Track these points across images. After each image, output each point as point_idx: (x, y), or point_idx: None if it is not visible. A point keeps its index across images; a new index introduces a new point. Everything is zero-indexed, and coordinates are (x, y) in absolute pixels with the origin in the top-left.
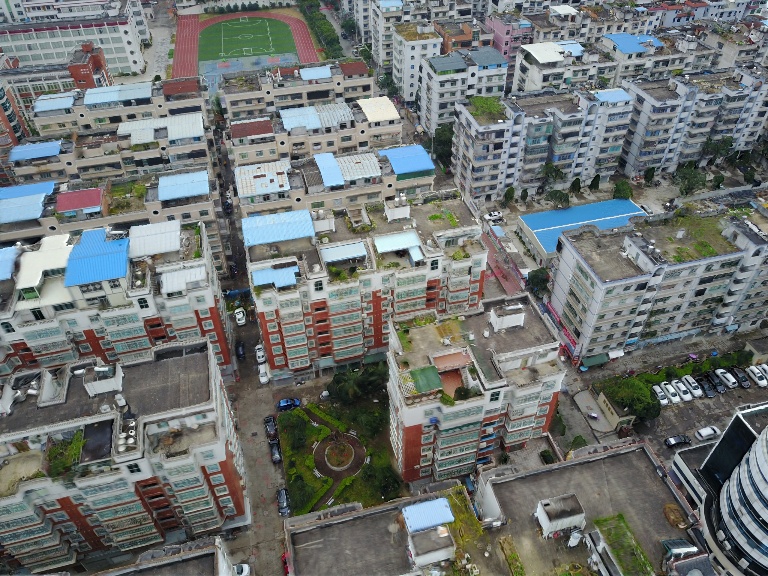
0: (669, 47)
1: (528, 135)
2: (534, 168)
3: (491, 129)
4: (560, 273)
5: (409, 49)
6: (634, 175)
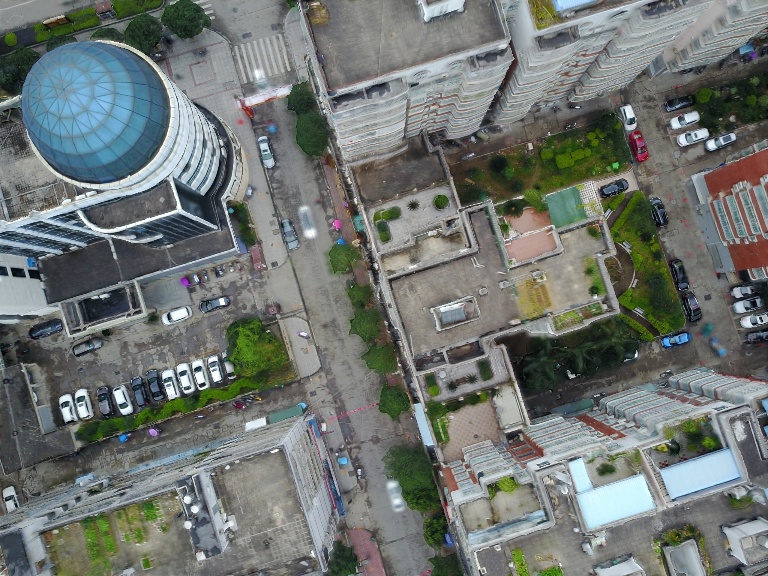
0: None
1: None
2: None
3: None
4: None
5: None
6: None
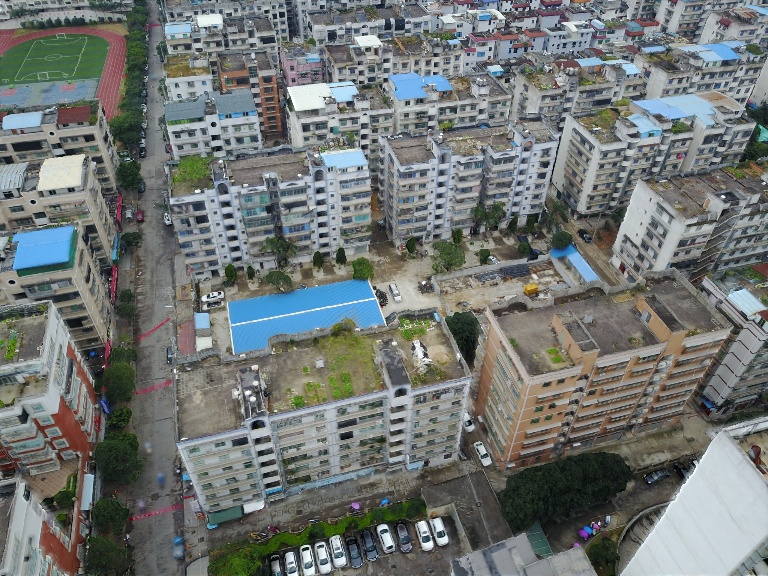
0: (463, 90)
1: (241, 206)
2: (260, 241)
3: (186, 201)
4: None
5: (173, 86)
6: (399, 243)
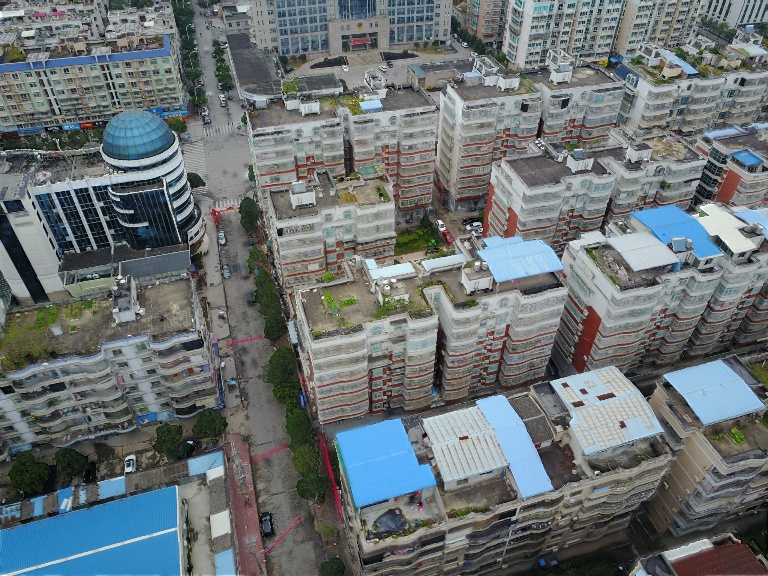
0: None
1: None
2: None
3: None
4: None
5: None
6: None
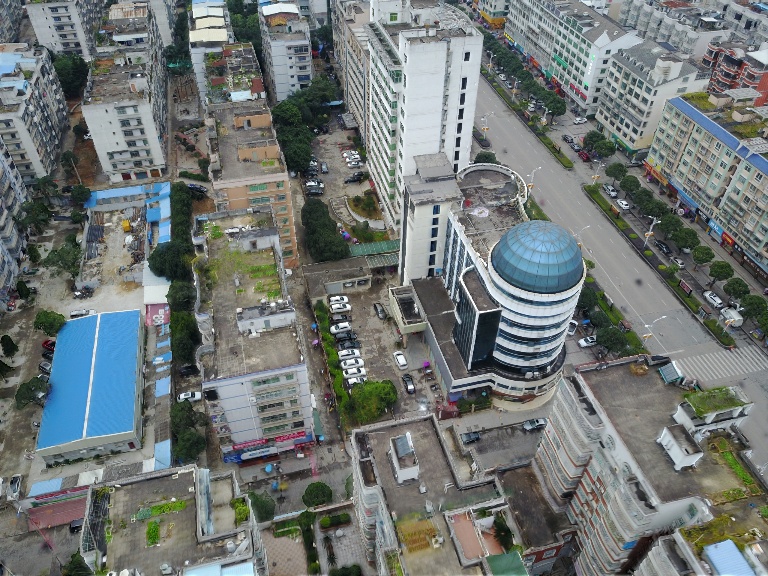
0: None
1: None
2: None
3: None
4: (230, 412)
5: None
6: (5, 306)
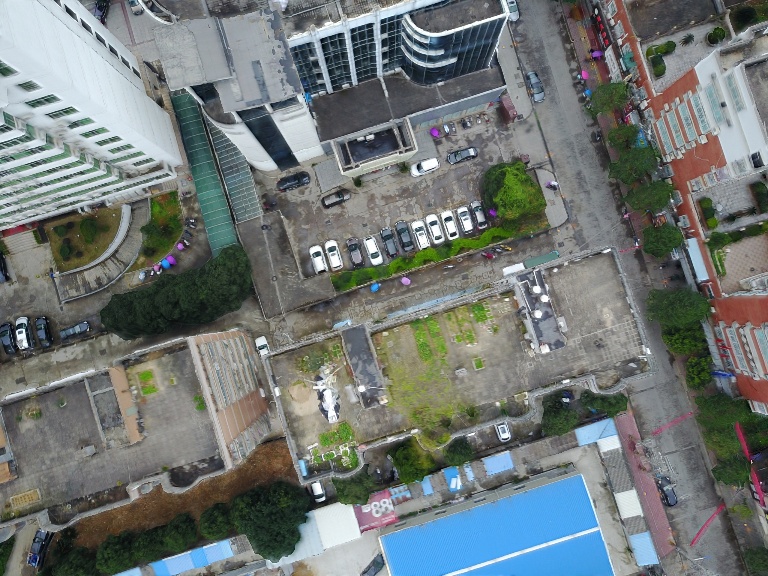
0: None
1: None
2: None
3: None
4: None
5: None
6: None
